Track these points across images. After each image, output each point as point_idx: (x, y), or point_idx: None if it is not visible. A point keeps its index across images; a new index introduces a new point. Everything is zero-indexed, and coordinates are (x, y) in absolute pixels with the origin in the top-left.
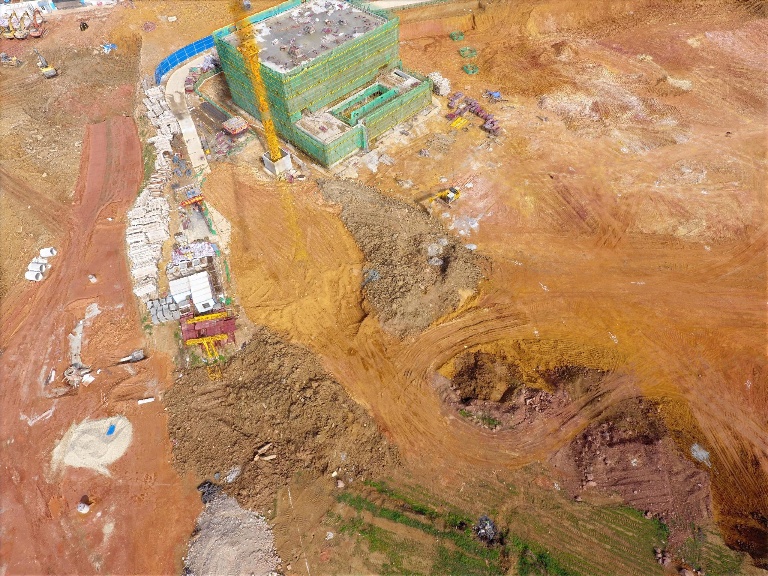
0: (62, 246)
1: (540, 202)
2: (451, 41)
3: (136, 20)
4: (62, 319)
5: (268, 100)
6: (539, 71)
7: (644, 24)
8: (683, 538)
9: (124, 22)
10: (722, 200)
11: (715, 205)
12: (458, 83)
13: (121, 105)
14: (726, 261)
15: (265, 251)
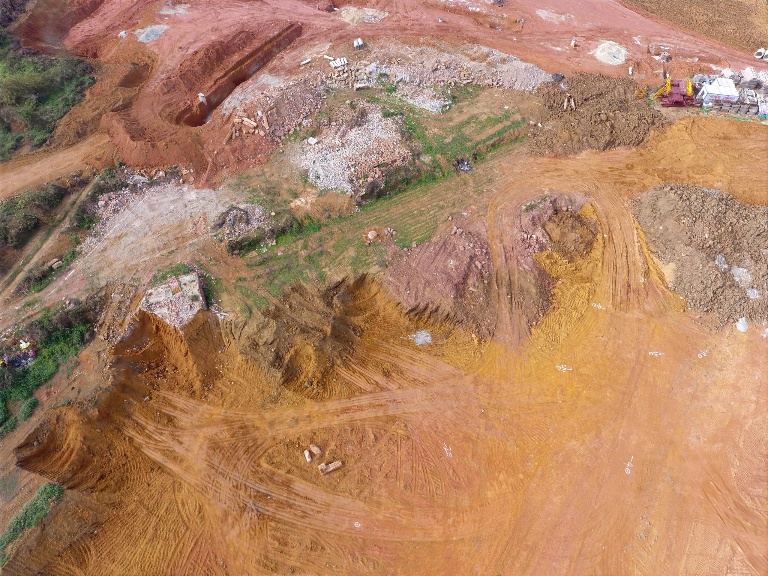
0: None
1: None
2: None
3: None
4: (713, 57)
5: None
6: None
7: None
8: (390, 251)
9: None
10: None
11: None
12: None
13: None
14: None
15: (760, 142)
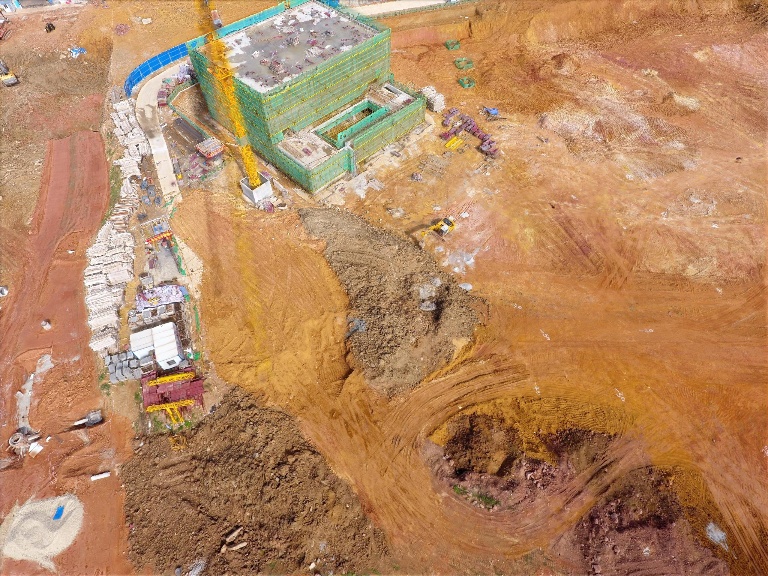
0: (14, 284)
1: (540, 235)
2: (446, 50)
3: (107, 22)
4: (9, 374)
5: (247, 119)
6: (539, 85)
7: (649, 35)
8: None
9: (94, 24)
10: (734, 235)
11: (726, 241)
12: (453, 98)
13: (88, 118)
14: (739, 306)
15: (240, 295)
